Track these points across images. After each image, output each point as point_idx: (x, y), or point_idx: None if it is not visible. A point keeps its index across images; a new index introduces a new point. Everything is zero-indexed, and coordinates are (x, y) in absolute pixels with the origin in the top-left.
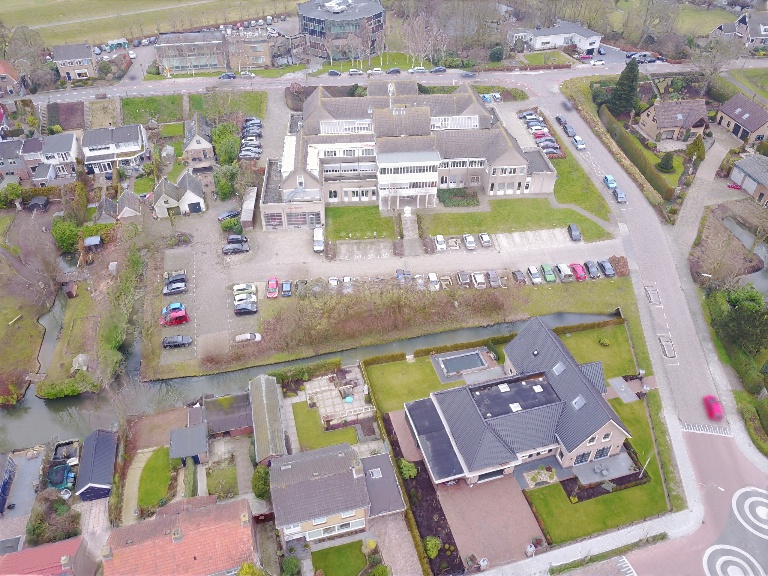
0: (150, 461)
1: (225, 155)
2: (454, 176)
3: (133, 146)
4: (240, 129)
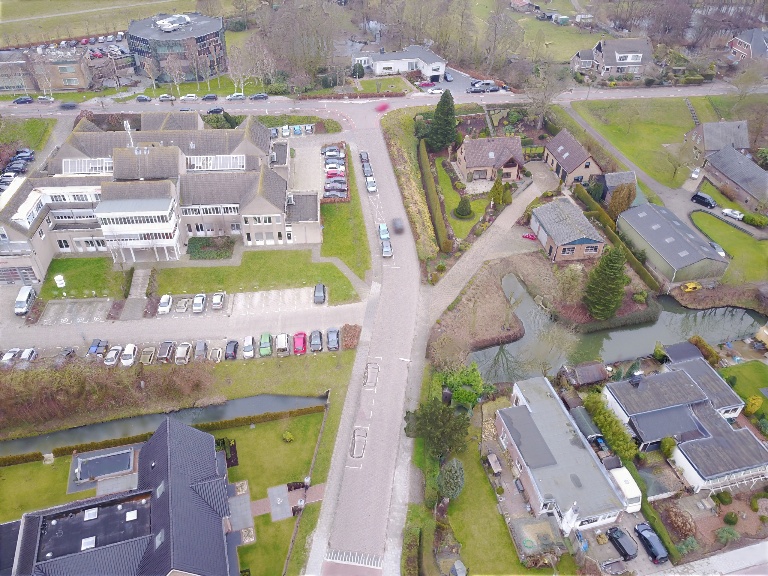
0: None
1: None
2: (210, 223)
3: None
4: (4, 163)
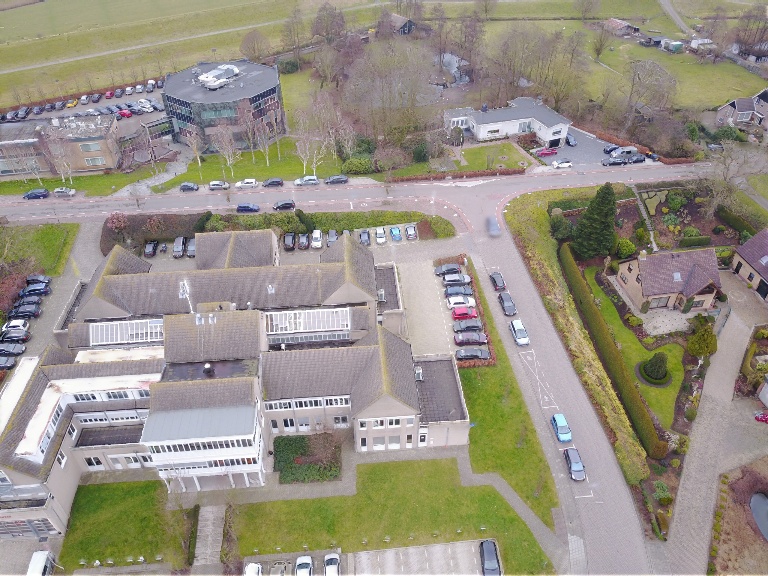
0: None
1: None
2: (304, 418)
3: None
4: (11, 300)
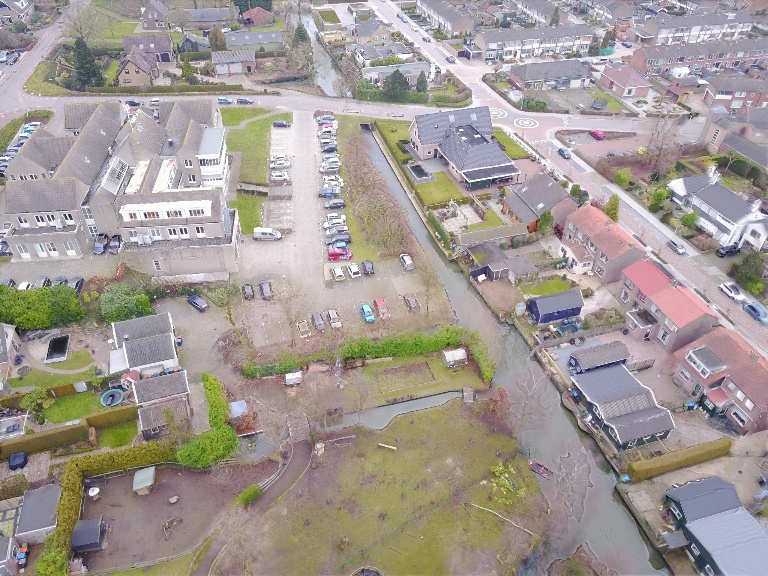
0: (535, 293)
1: (73, 299)
2: None
3: None
4: None
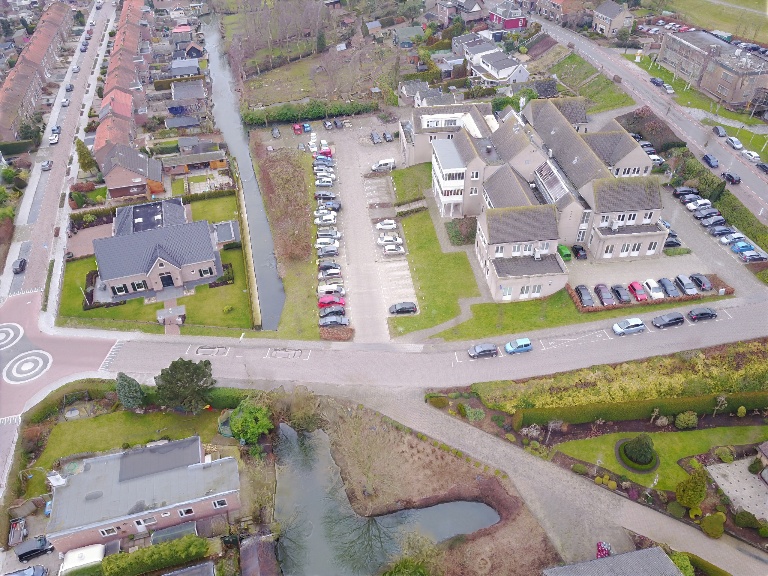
0: None
1: None
2: None
3: (497, 73)
4: None
